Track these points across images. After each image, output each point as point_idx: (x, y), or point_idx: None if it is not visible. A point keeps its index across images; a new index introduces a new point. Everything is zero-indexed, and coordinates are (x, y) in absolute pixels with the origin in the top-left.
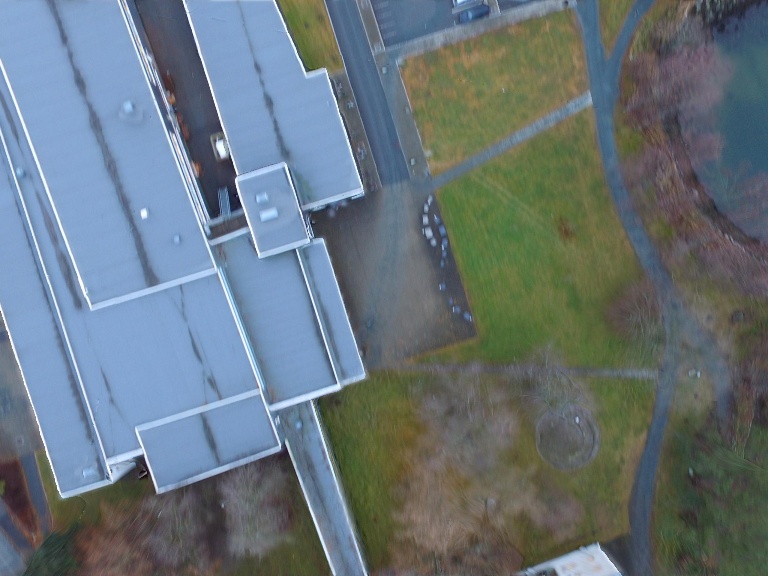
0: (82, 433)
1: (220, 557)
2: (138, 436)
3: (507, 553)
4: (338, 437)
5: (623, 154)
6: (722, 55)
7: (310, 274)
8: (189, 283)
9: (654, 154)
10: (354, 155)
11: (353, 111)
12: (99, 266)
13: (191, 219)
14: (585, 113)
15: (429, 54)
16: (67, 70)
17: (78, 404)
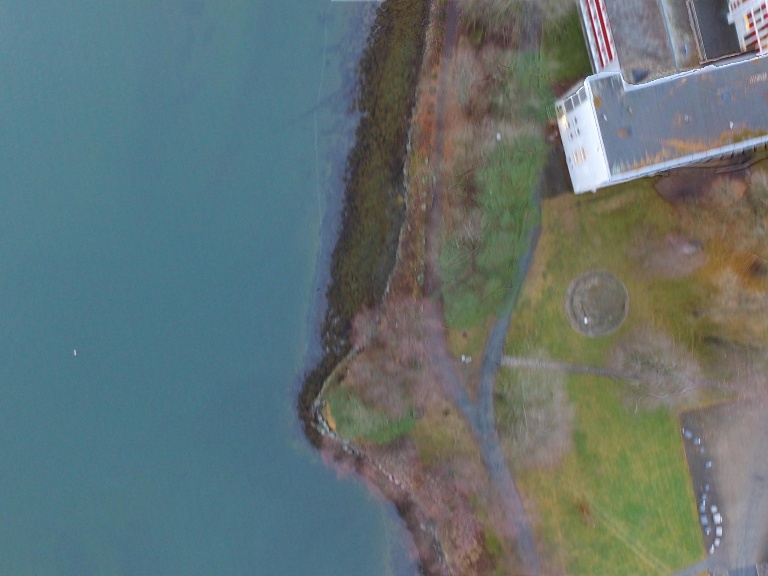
0: None
1: None
2: None
3: (694, 205)
4: None
5: None
6: None
7: None
8: None
9: None
10: None
11: None
12: None
13: None
14: None
15: None
16: None
17: None
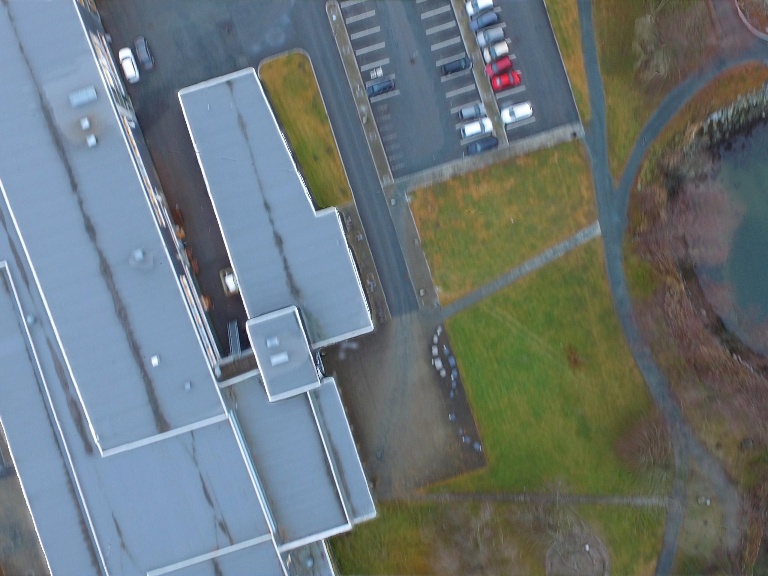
0: None
1: None
2: None
3: None
4: (348, 568)
5: (632, 283)
6: (729, 172)
7: (320, 413)
8: (200, 429)
9: (662, 281)
10: (363, 288)
11: (362, 243)
12: (110, 412)
13: (202, 365)
14: (594, 243)
15: (438, 185)
16: (77, 217)
17: (89, 549)
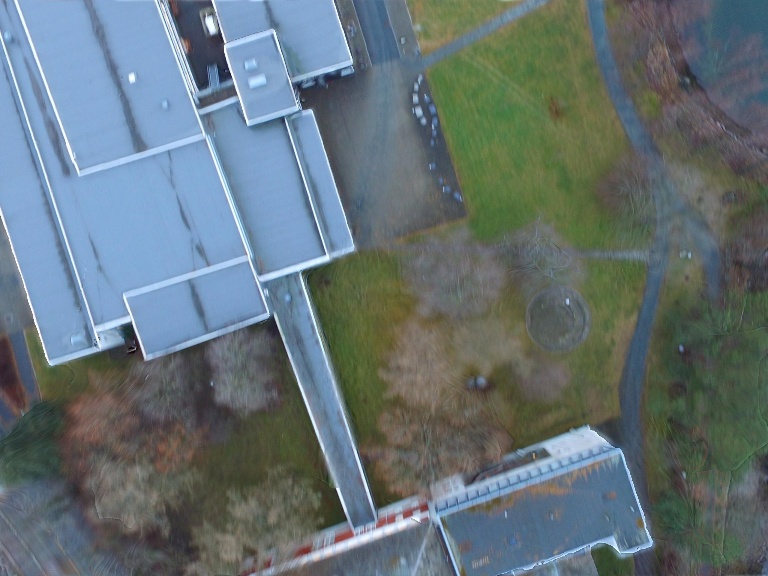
0: (70, 300)
1: (208, 424)
2: (126, 303)
3: (496, 428)
4: (328, 317)
5: (614, 34)
6: None
7: (299, 145)
8: (177, 149)
9: (645, 36)
10: (344, 32)
11: None
12: (87, 132)
13: (179, 84)
14: None
15: None
16: None
17: (66, 271)
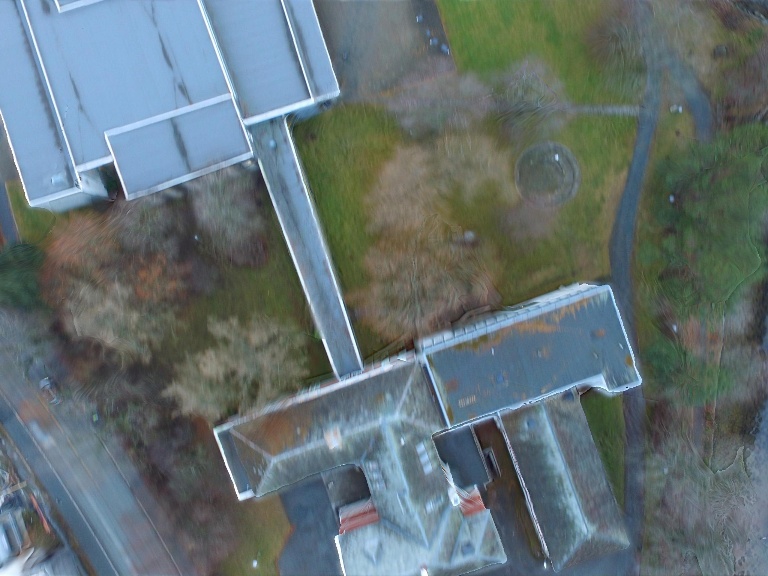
0: (51, 141)
1: (191, 265)
2: (107, 141)
3: (484, 277)
4: (314, 172)
5: None
6: None
7: None
8: None
9: None
10: None
11: None
12: None
13: None
14: None
15: None
16: None
17: (47, 111)
